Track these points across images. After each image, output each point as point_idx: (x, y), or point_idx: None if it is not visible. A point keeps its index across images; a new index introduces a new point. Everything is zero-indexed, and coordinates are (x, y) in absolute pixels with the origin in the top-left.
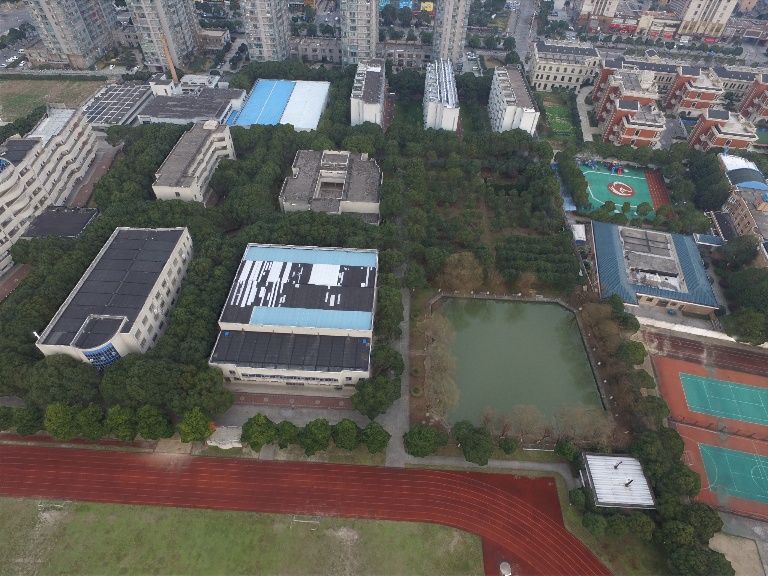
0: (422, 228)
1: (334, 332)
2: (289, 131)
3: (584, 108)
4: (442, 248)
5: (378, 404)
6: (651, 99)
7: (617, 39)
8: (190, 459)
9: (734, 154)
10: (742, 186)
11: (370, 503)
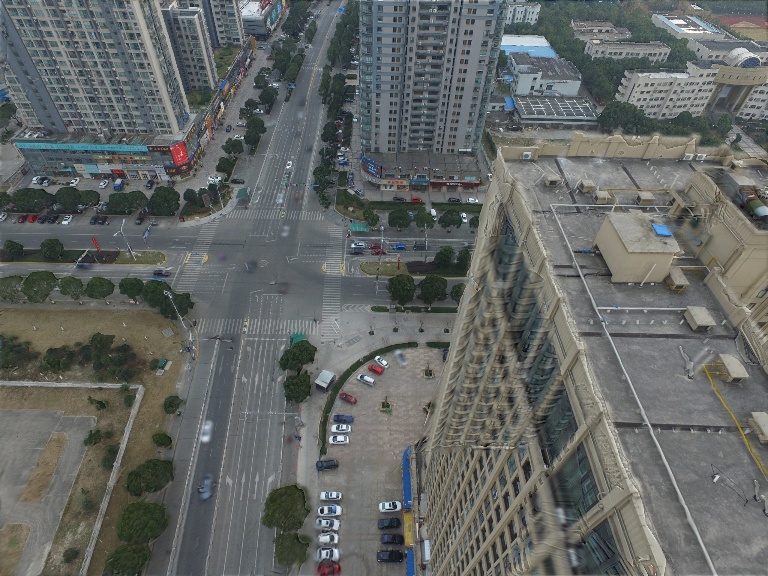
0: None
1: None
2: None
3: None
4: None
5: None
6: None
7: None
8: None
9: None
10: None
11: None
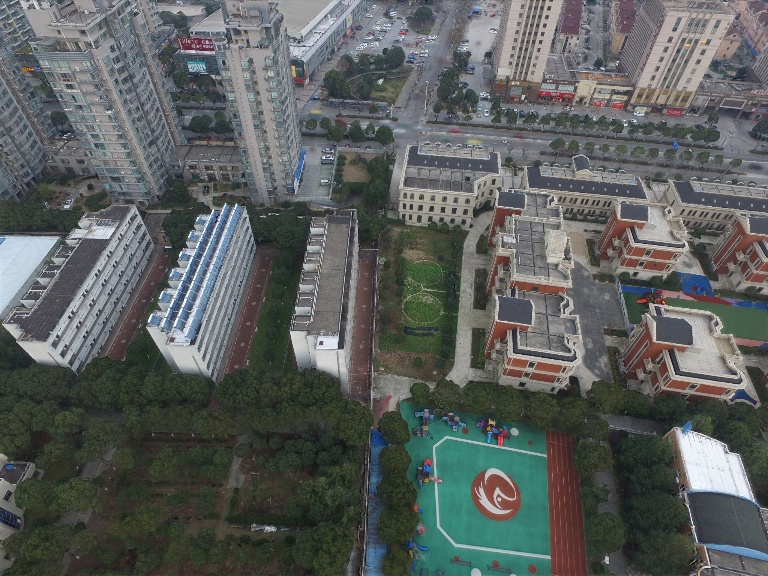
0: None
1: None
2: None
3: (472, 263)
4: None
5: None
6: (561, 287)
7: (543, 120)
8: None
9: (702, 430)
10: (717, 549)
11: None
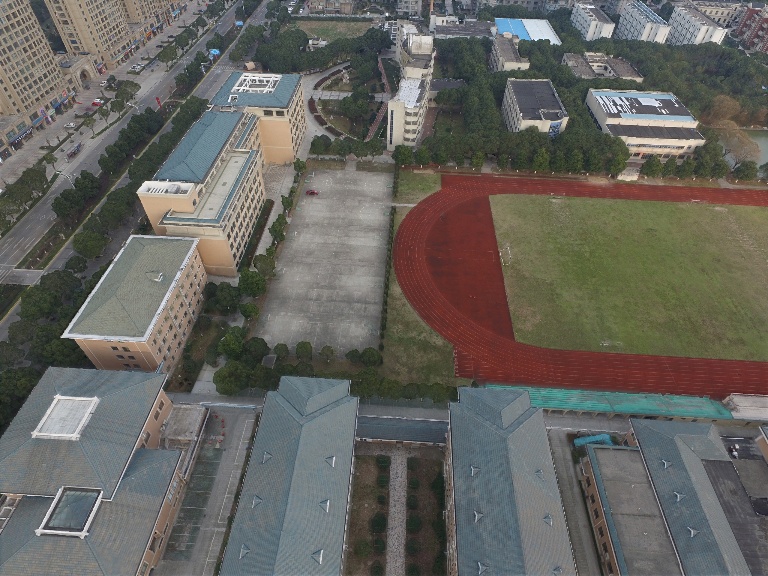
0: None
1: (675, 124)
2: (549, 44)
3: None
4: None
5: (714, 156)
6: None
7: None
8: (611, 184)
9: None
10: None
11: (725, 199)
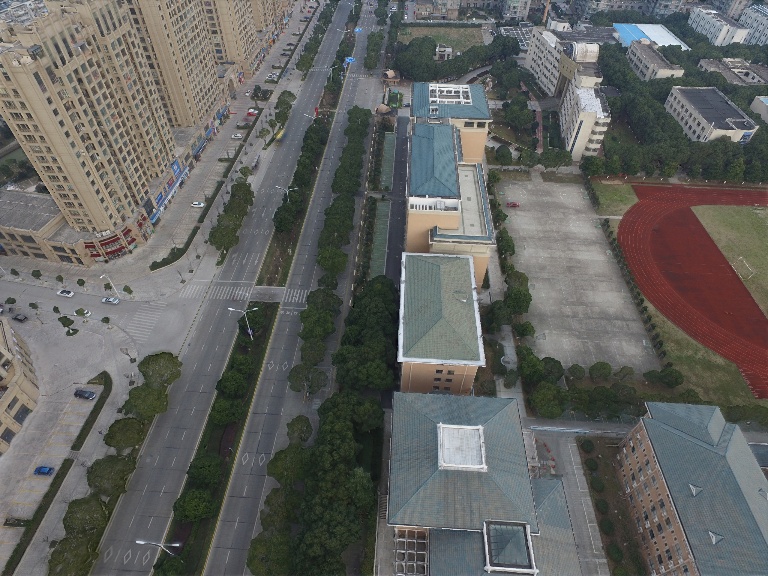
0: None
1: None
2: None
3: None
4: None
5: None
6: None
7: None
8: None
9: None
10: None
11: None
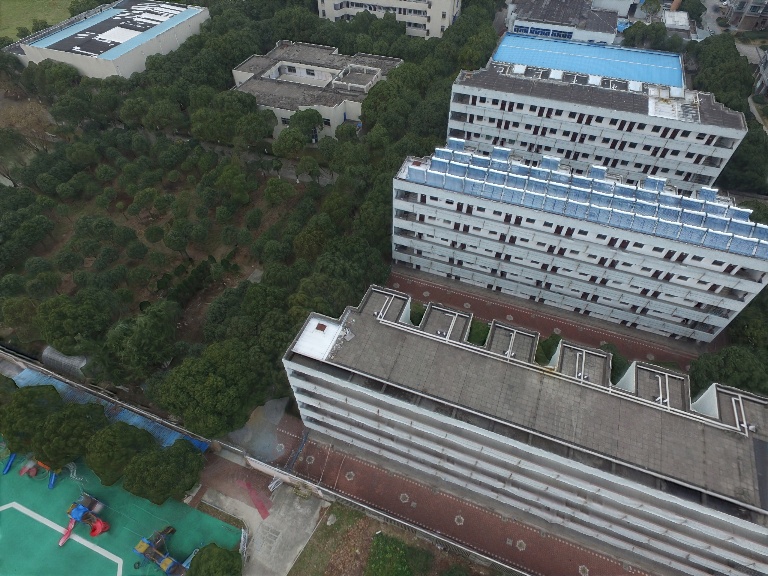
0: (125, 107)
1: None
2: (462, 57)
3: None
4: (98, 138)
5: None
6: None
7: None
8: None
9: None
10: None
11: None
